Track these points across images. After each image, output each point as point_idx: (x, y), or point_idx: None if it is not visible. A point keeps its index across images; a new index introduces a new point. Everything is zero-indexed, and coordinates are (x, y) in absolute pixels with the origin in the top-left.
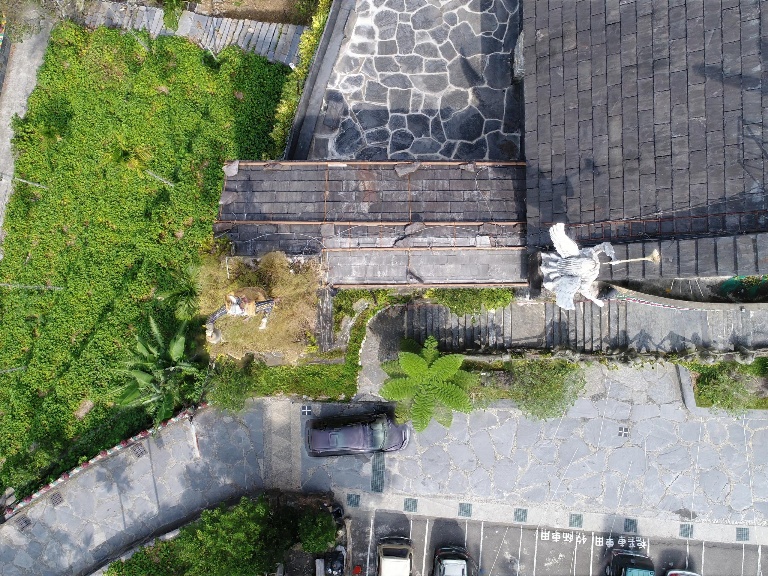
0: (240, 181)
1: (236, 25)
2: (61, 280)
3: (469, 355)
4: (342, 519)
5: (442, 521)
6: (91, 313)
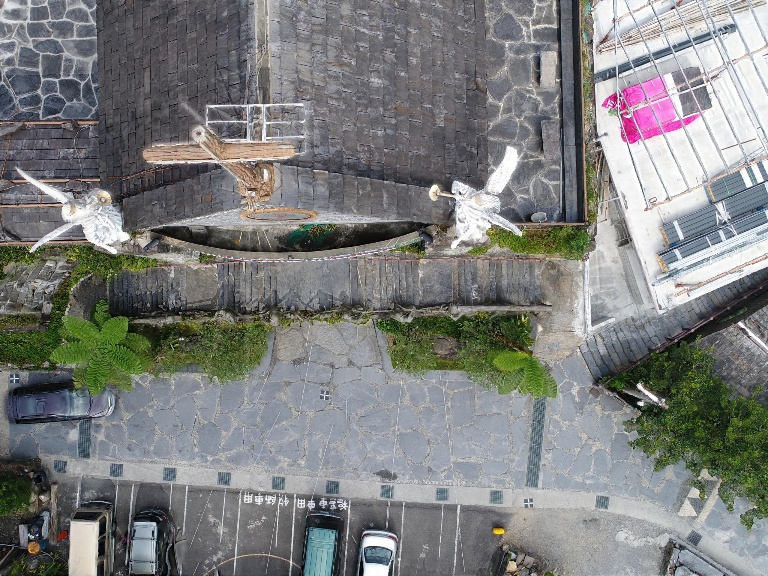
0: None
1: None
2: None
3: (142, 318)
4: (49, 485)
5: (147, 486)
6: None
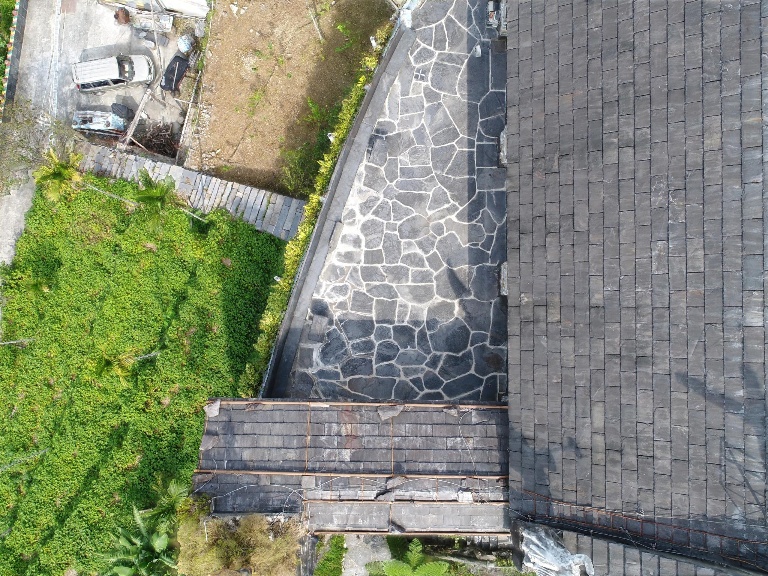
0: (221, 422)
1: (225, 187)
2: (47, 436)
3: (454, 557)
4: None
5: None
6: (76, 475)
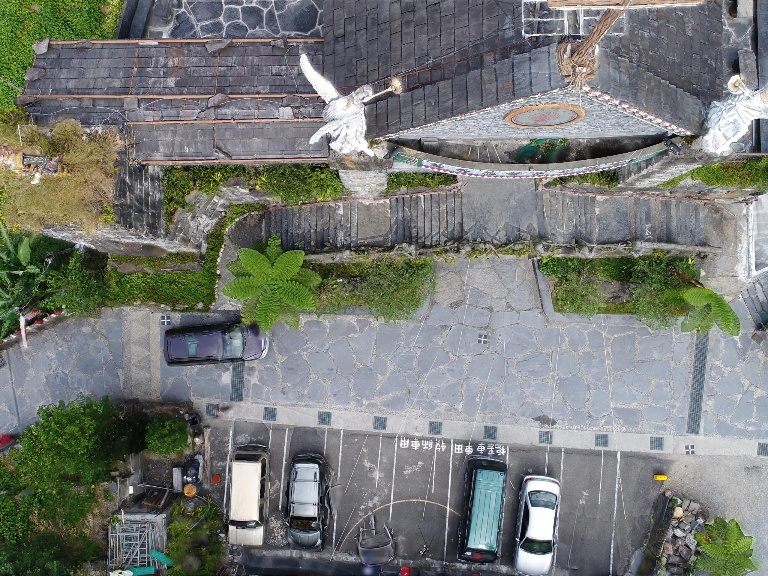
0: (49, 59)
1: None
2: None
3: (314, 254)
4: (201, 429)
5: (301, 430)
6: None
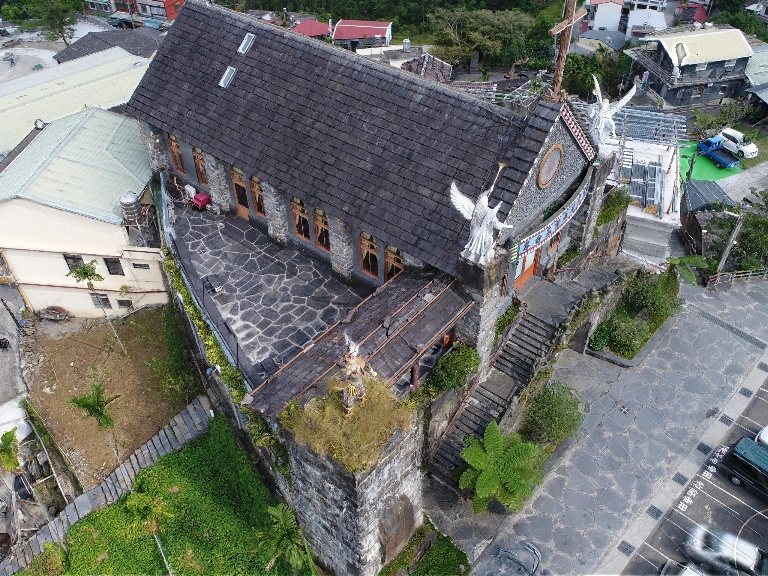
0: (260, 399)
1: (130, 463)
2: None
3: None
4: None
5: (626, 573)
6: None
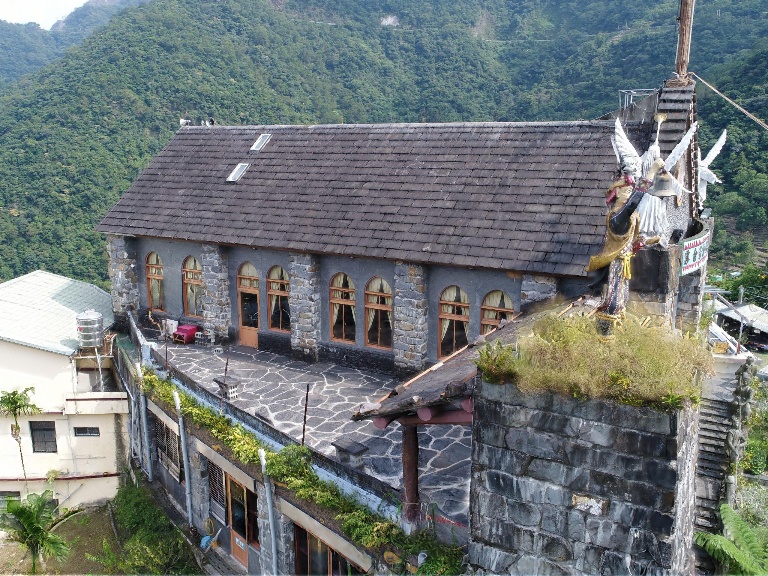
0: (394, 403)
1: None
2: None
3: None
4: None
5: None
6: None
